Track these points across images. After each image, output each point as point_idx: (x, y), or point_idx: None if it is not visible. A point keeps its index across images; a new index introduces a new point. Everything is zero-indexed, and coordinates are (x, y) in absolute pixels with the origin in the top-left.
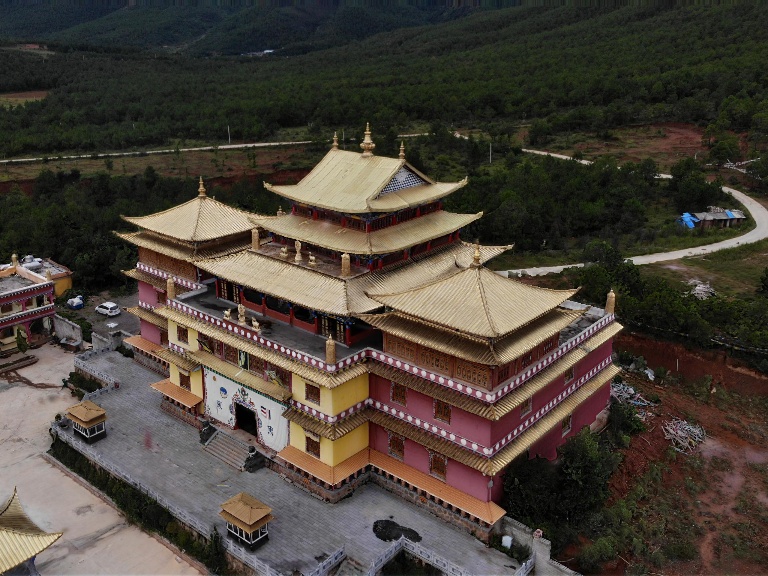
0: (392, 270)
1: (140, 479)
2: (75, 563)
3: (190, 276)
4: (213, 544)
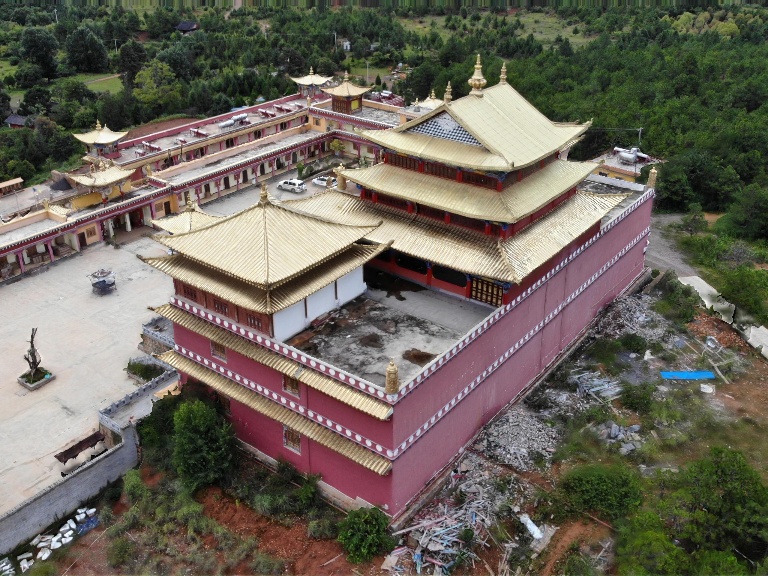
0: (379, 210)
1: None
2: None
3: None
4: None
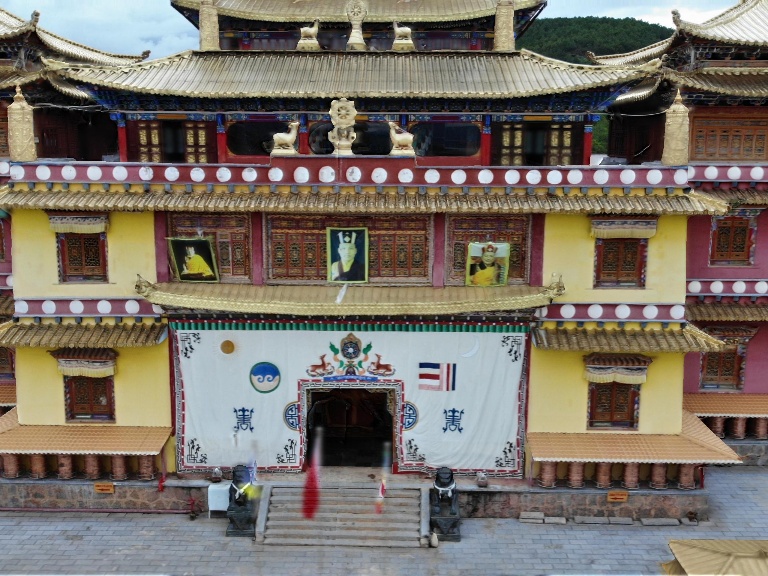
0: None
1: None
2: None
3: (1, 147)
4: None
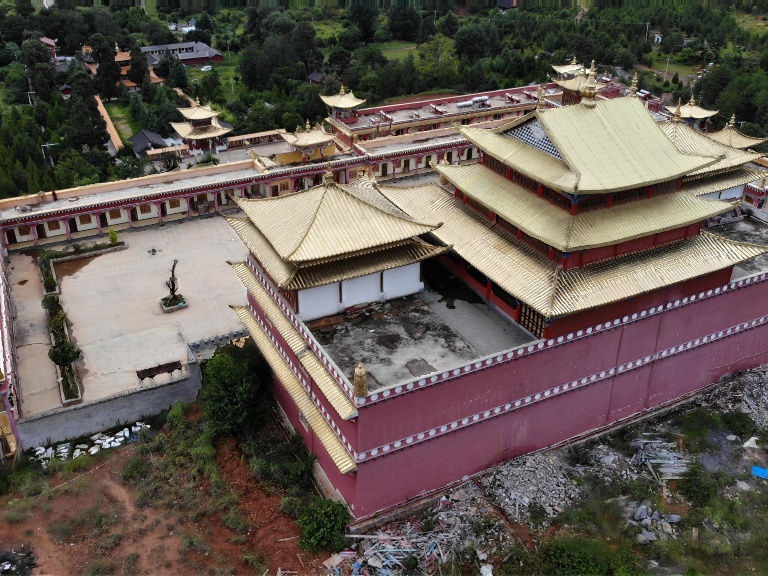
0: (465, 212)
1: None
2: None
3: None
4: None
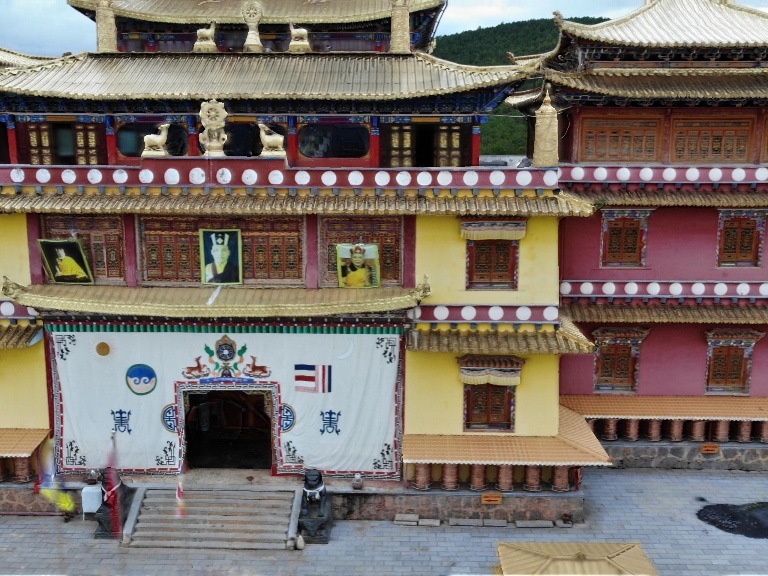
0: None
1: None
2: None
3: None
4: None
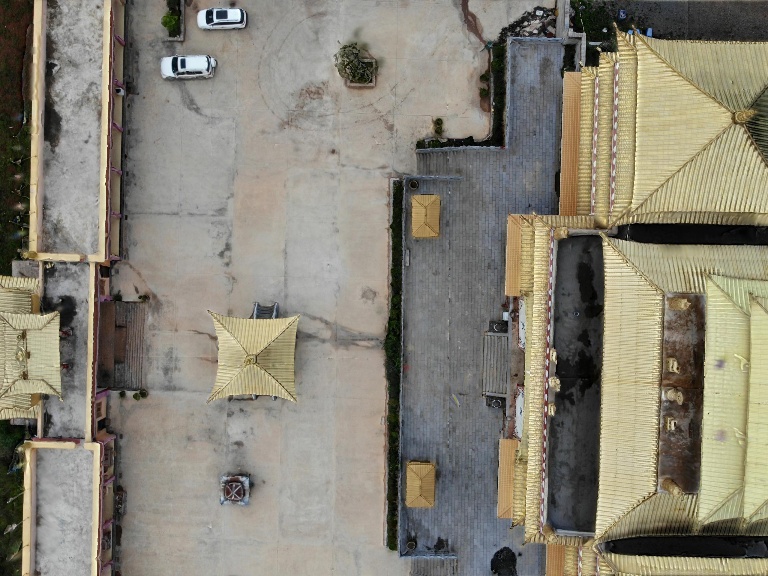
0: None
1: (412, 328)
2: (325, 356)
3: None
4: (391, 467)
